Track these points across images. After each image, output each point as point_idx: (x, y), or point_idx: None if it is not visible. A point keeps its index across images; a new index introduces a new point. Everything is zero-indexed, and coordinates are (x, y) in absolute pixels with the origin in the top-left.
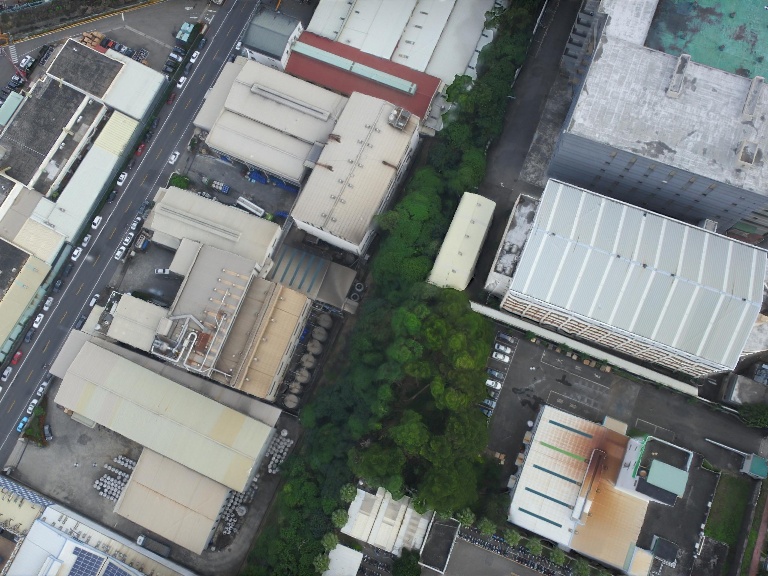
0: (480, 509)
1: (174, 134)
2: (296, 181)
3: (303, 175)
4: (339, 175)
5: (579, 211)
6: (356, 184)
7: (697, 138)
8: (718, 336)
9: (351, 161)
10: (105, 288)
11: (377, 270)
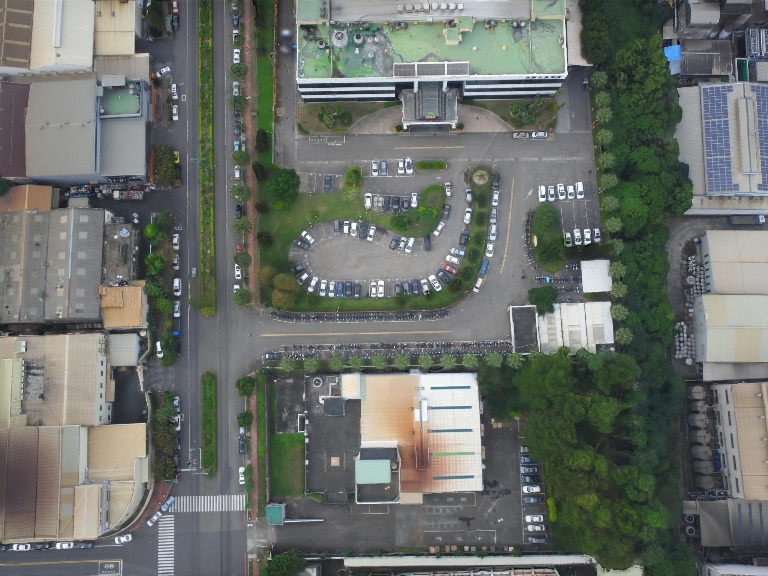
0: (504, 372)
1: None
2: None
3: None
4: None
5: None
6: None
7: None
8: None
9: None
10: None
11: None
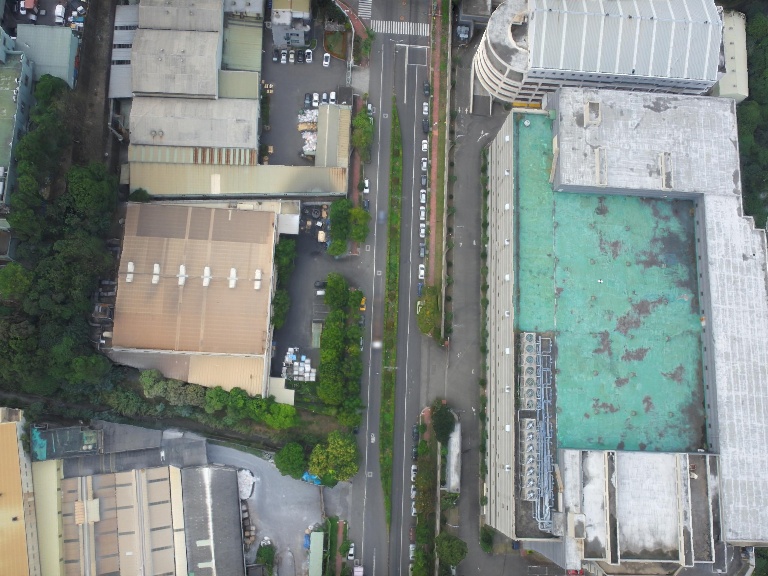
0: None
1: None
2: None
3: None
4: None
5: (688, 55)
6: None
7: (631, 123)
8: None
9: None
10: None
11: None
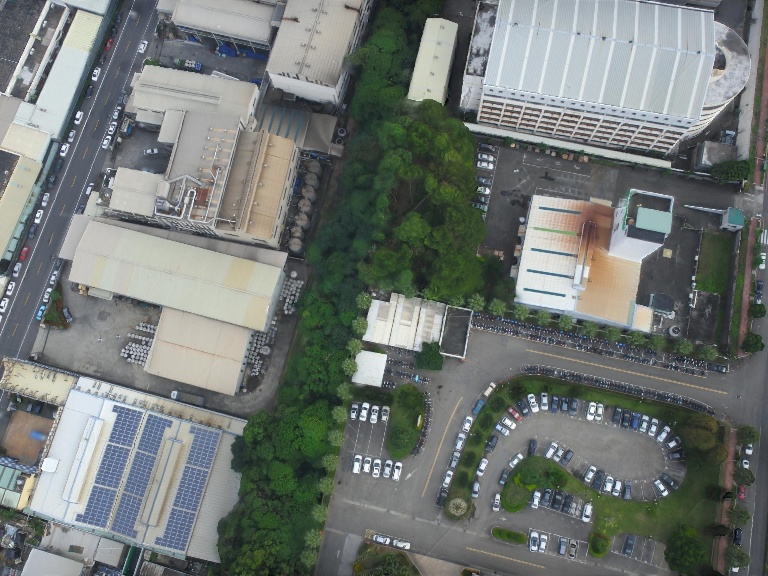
0: (488, 295)
1: (139, 25)
2: (265, 42)
3: (271, 35)
4: (306, 24)
5: (536, 3)
6: (323, 30)
7: None
8: (680, 92)
9: (315, 9)
10: (98, 175)
11: (356, 105)
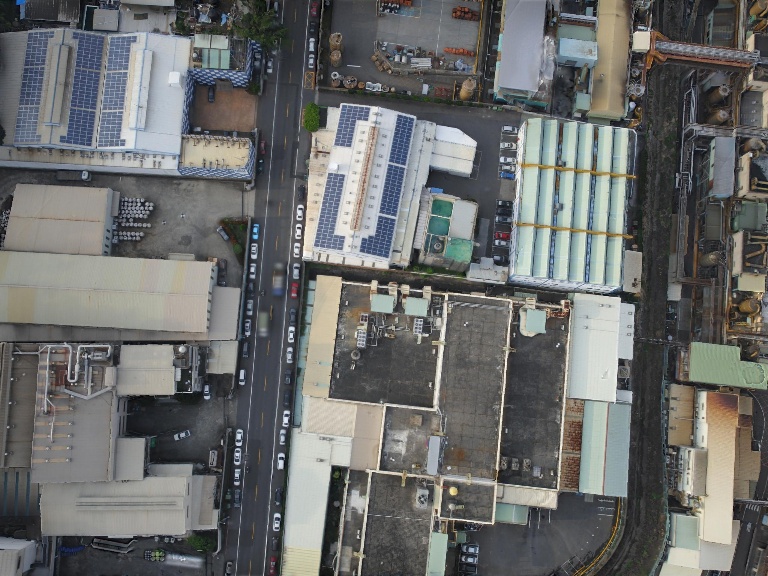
0: None
1: None
2: None
3: None
4: None
5: None
6: None
7: None
8: None
9: None
10: None
11: None
